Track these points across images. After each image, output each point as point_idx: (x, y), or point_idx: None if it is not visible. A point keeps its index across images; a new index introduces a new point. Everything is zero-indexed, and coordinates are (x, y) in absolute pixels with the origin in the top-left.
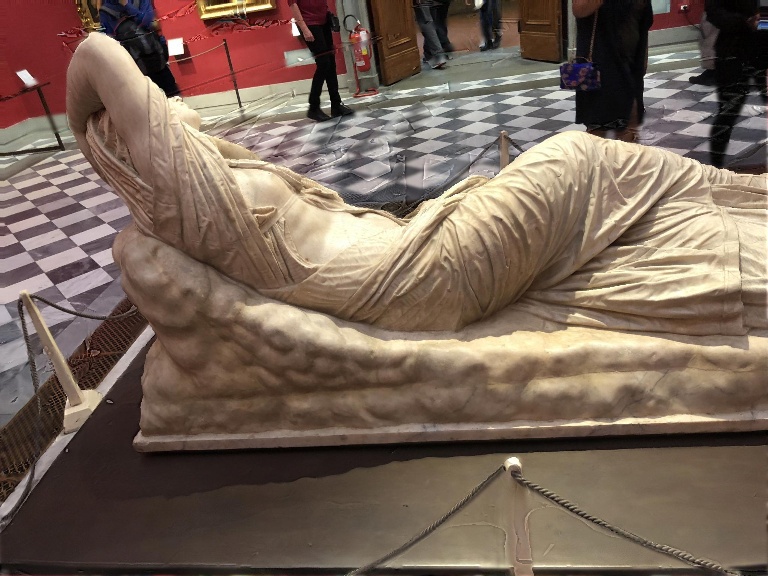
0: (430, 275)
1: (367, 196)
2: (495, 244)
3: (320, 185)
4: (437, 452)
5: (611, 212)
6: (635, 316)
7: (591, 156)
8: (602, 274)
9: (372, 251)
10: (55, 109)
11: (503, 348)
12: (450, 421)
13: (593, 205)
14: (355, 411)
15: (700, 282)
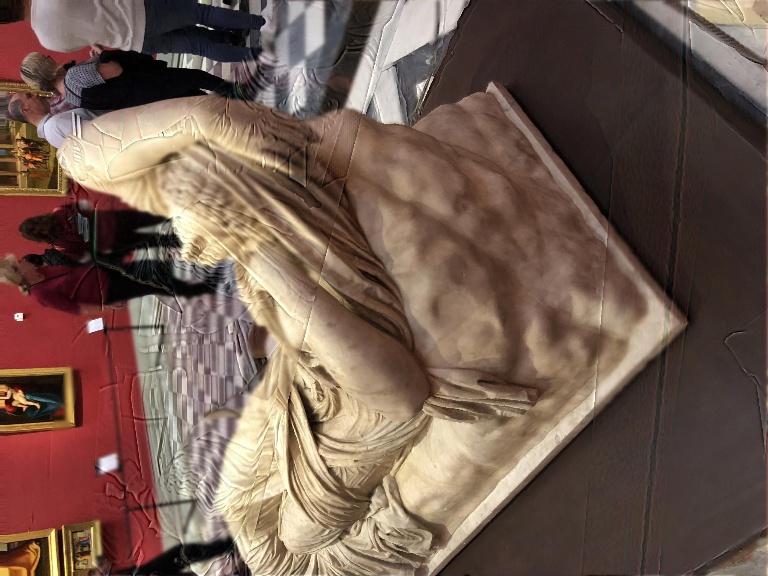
0: None
1: None
2: None
3: None
4: None
5: None
6: None
7: None
8: None
9: None
10: (625, 7)
11: None
12: None
13: None
14: None
15: None
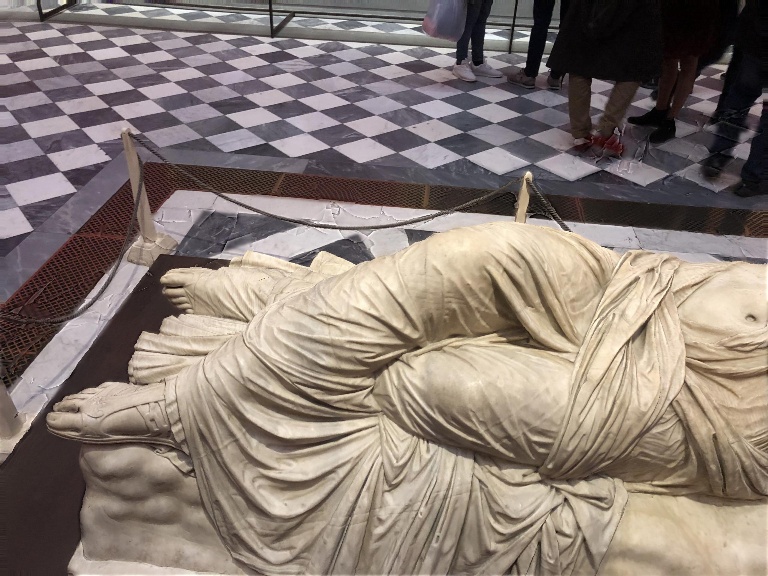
0: None
1: None
2: None
3: None
4: None
5: None
6: None
7: None
8: None
9: None
10: None
11: None
12: None
13: None
14: None
15: None
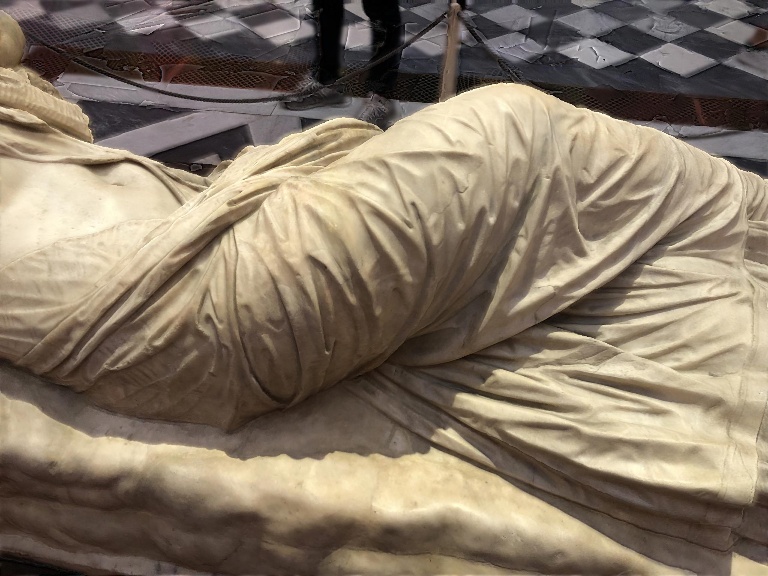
0: (177, 342)
1: (249, 66)
2: (305, 312)
3: (37, 94)
4: None
5: (553, 265)
6: (546, 467)
7: (539, 152)
8: (508, 377)
9: (73, 273)
10: None
11: (297, 490)
12: (200, 570)
13: (520, 254)
14: (40, 529)
15: (677, 456)
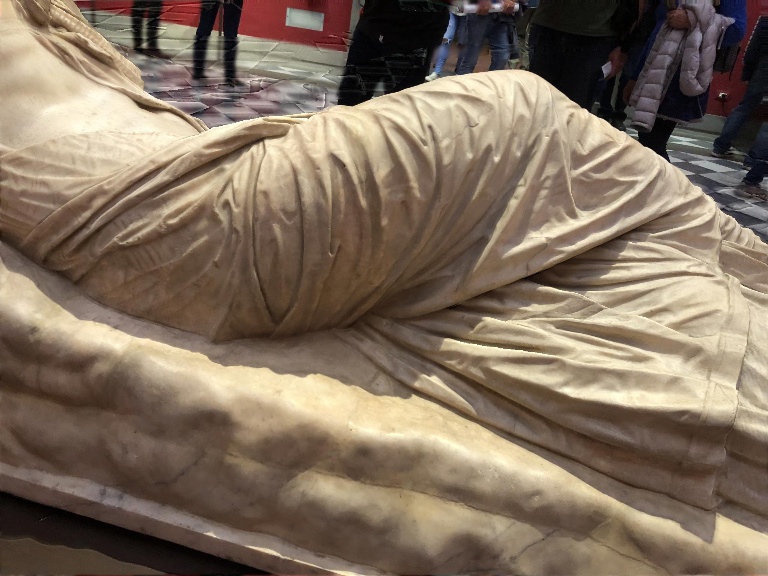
0: (190, 225)
1: None
2: (318, 205)
3: (109, 45)
4: (112, 545)
5: (546, 222)
6: (529, 412)
7: (541, 116)
8: (497, 322)
9: (109, 154)
10: None
11: (275, 396)
12: (149, 497)
13: (518, 198)
14: None
15: (659, 387)
